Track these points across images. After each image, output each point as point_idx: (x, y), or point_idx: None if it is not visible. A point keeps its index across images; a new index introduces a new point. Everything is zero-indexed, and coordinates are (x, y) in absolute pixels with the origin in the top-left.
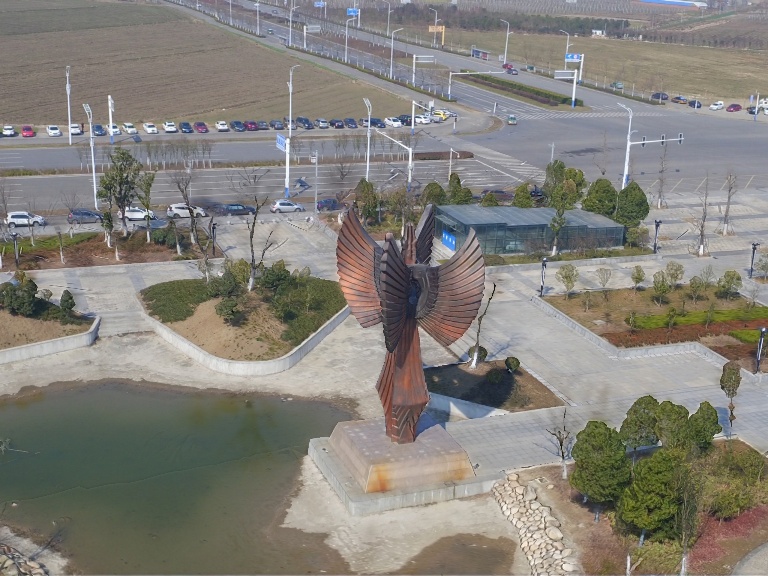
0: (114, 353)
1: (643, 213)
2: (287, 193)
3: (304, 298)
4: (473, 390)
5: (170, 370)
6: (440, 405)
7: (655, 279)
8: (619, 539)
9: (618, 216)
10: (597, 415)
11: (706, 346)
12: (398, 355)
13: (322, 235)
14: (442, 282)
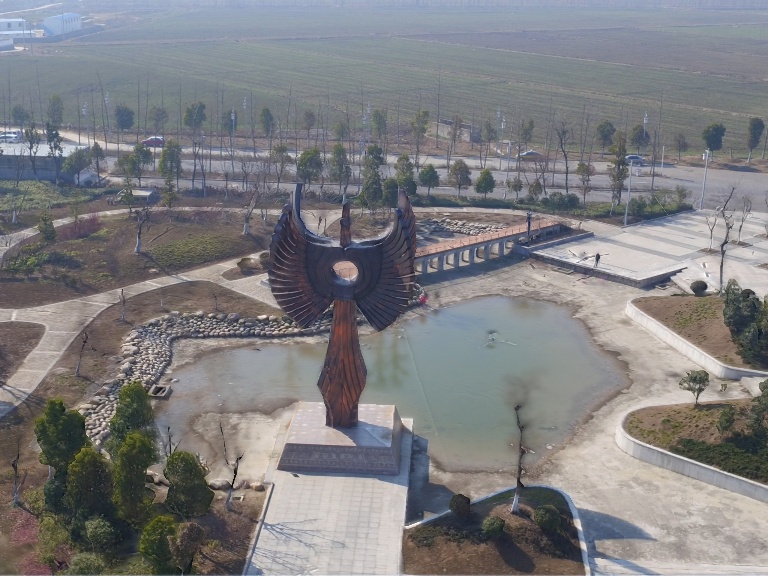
0: None
1: None
2: None
3: None
4: None
5: (645, 404)
6: None
7: None
8: None
9: None
10: None
11: None
12: None
13: None
14: None
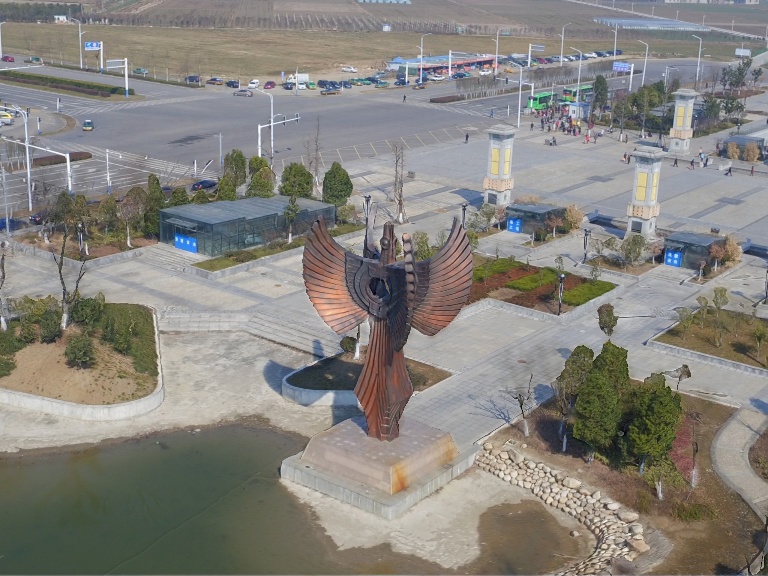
0: None
1: (349, 191)
2: None
3: None
4: None
5: (39, 432)
6: (346, 401)
7: (420, 249)
8: (622, 472)
9: (328, 197)
10: (486, 377)
11: (500, 300)
12: (388, 354)
13: (36, 259)
14: (433, 275)
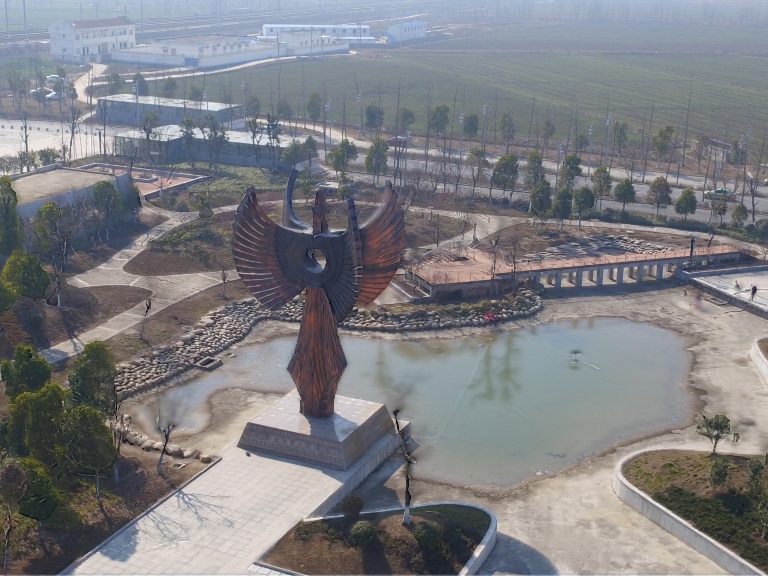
0: (766, 439)
1: None
2: None
3: None
4: None
5: (686, 448)
6: None
7: None
8: None
9: None
10: (209, 563)
11: None
12: None
13: None
14: None
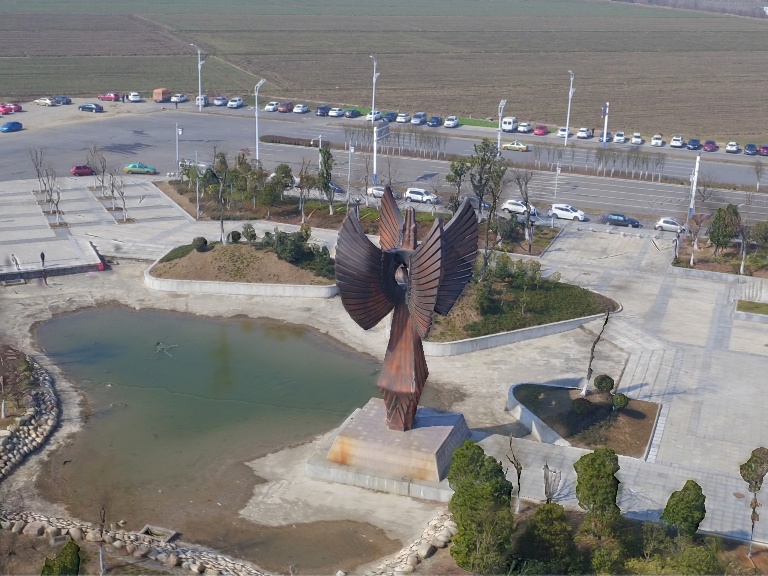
0: (336, 308)
1: None
2: (691, 214)
3: (534, 300)
4: (560, 415)
5: (357, 331)
6: (527, 421)
7: None
8: None
9: None
10: (658, 477)
11: None
12: None
13: (667, 256)
14: (413, 270)
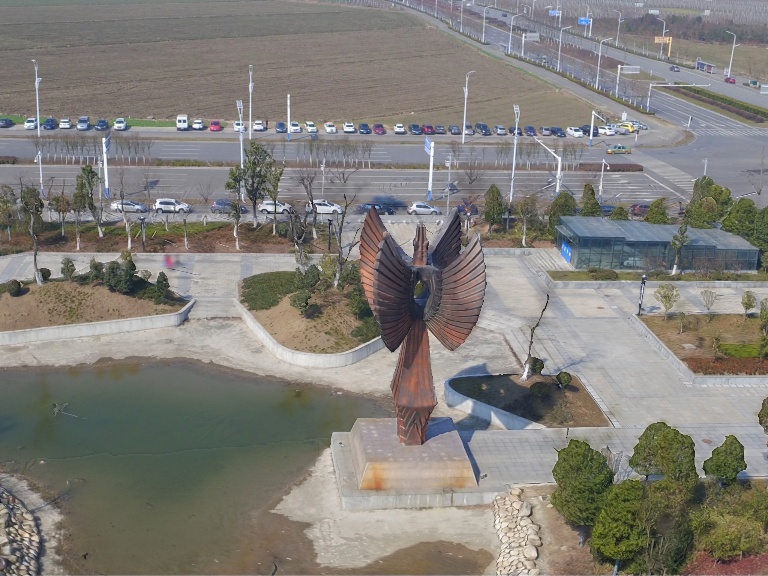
0: (196, 335)
1: None
2: (430, 196)
3: None
4: (517, 401)
5: (240, 355)
6: (482, 413)
7: (762, 306)
8: (594, 566)
9: (753, 238)
10: None
11: None
12: (406, 356)
13: None
14: (445, 285)
